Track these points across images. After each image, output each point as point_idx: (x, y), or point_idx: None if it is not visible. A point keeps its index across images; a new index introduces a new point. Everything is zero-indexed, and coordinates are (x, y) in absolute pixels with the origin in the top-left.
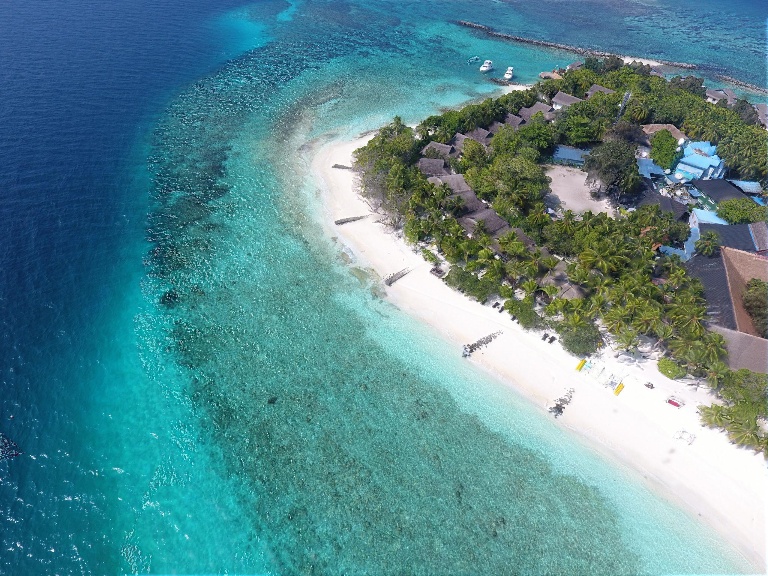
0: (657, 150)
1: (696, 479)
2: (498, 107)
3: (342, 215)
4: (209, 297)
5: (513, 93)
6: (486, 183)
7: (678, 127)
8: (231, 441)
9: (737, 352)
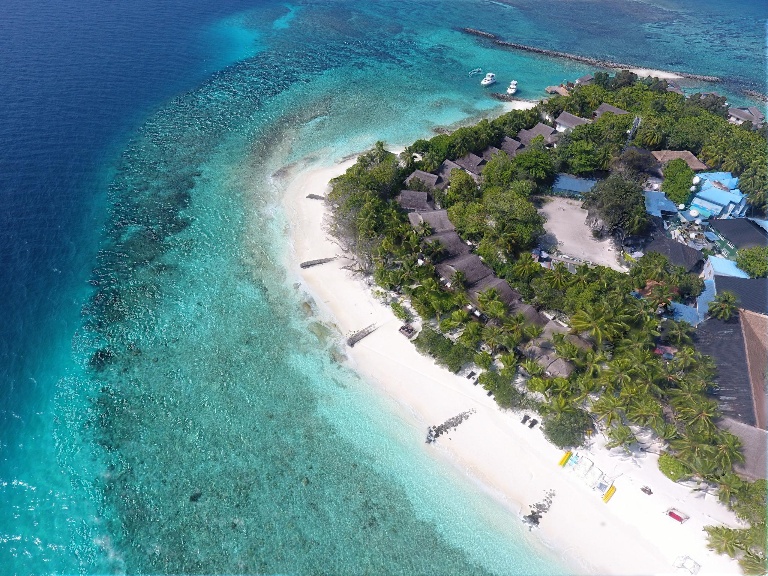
0: (670, 182)
1: None
2: (494, 130)
3: (309, 256)
4: (145, 357)
5: (512, 113)
6: (471, 222)
7: (695, 153)
8: (138, 552)
9: (756, 453)
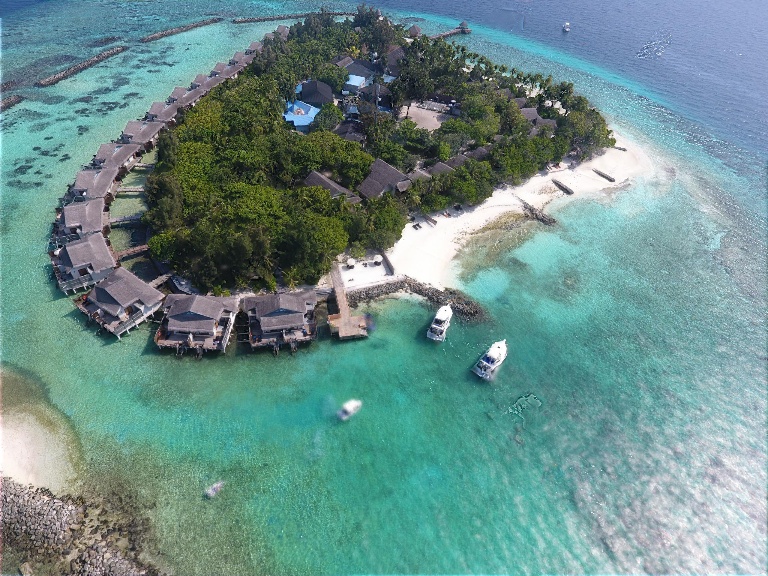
0: None
1: None
2: None
3: None
4: None
5: None
6: None
7: None
8: None
9: None
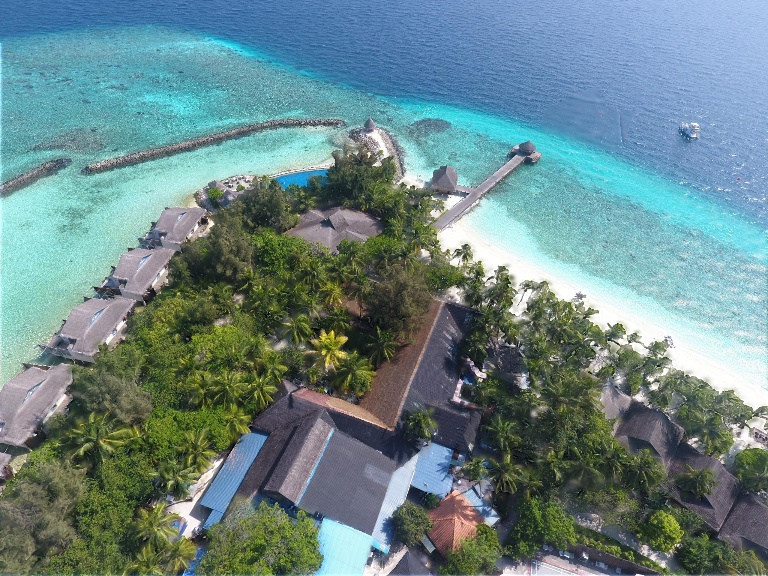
0: None
1: (487, 257)
2: None
3: None
4: None
5: None
6: None
7: None
8: None
9: None
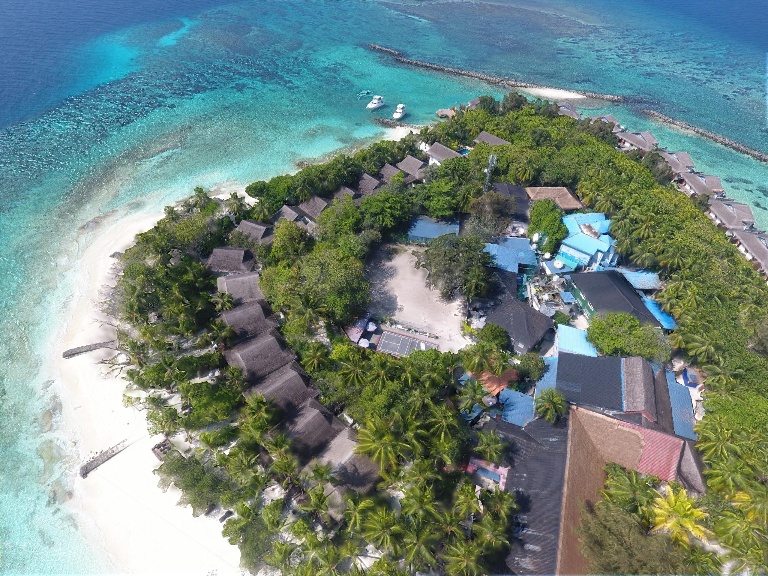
0: (535, 227)
1: None
2: (347, 167)
3: (80, 340)
4: None
5: (374, 146)
6: None
7: (574, 188)
8: None
9: None
